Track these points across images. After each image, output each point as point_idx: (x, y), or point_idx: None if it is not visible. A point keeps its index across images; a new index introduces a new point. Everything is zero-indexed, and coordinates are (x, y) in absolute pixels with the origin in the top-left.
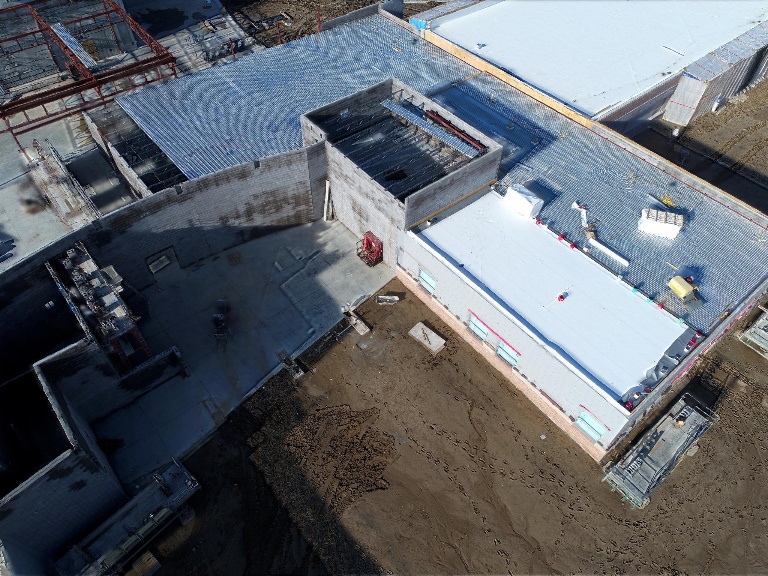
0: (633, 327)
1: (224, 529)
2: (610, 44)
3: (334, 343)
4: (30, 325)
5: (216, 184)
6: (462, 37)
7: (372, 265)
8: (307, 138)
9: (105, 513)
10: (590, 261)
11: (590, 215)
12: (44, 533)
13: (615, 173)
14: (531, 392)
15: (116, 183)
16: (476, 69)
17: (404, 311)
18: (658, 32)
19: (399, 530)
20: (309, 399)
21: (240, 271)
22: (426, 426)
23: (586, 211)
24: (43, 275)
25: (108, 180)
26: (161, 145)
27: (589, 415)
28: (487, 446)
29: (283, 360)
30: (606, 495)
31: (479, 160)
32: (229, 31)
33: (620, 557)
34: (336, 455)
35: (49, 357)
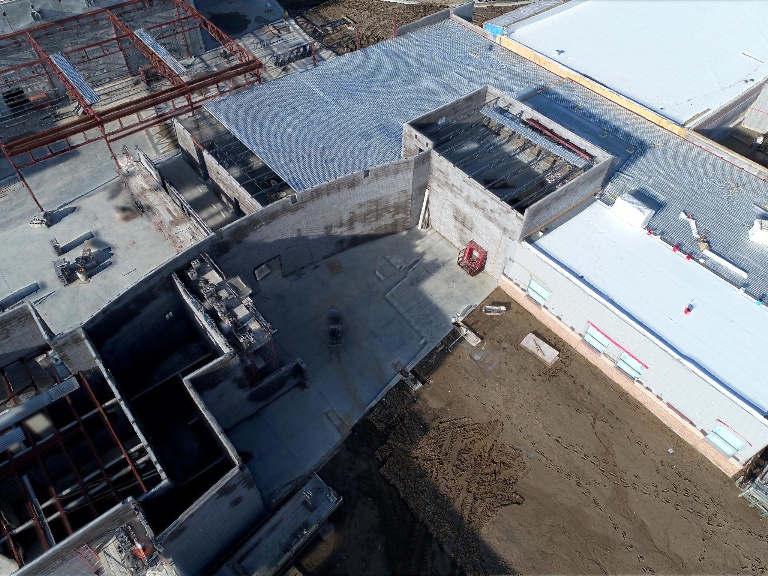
0: (764, 340)
1: (365, 544)
2: (688, 50)
3: (447, 354)
4: (151, 336)
5: (327, 193)
6: (539, 43)
7: (474, 274)
8: (408, 146)
9: (247, 528)
10: (708, 273)
11: (699, 225)
12: (201, 550)
13: (715, 182)
14: (655, 405)
15: (204, 190)
16: (557, 75)
17: (512, 321)
18: (733, 38)
19: (540, 546)
20: (430, 411)
21: (342, 280)
22: (552, 439)
23: (695, 221)
24: (168, 286)
25: (196, 187)
26: (258, 153)
27: (727, 430)
28: (616, 460)
29: (399, 371)
30: (743, 510)
31: (592, 170)
32: (294, 35)
33: (766, 574)
34: (466, 469)
35: (198, 371)
